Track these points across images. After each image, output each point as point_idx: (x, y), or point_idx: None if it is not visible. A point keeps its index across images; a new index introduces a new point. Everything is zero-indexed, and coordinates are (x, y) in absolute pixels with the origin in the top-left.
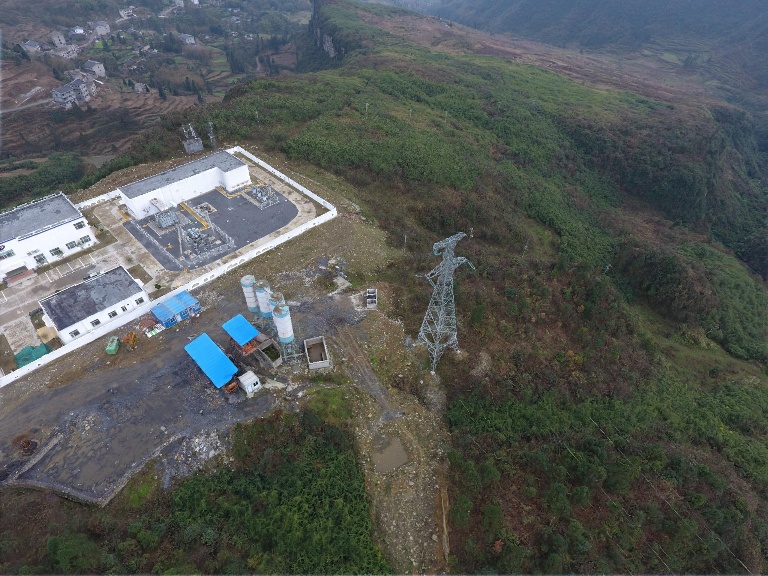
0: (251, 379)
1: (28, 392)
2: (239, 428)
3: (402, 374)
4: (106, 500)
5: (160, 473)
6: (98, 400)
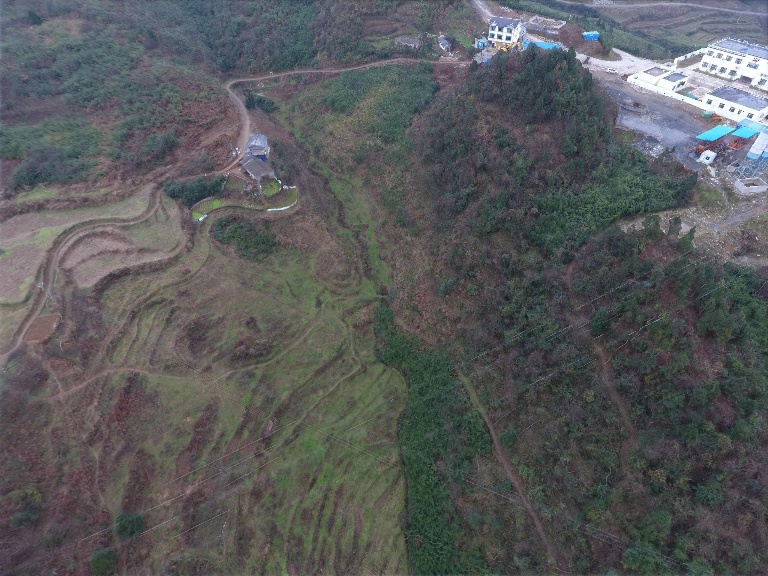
0: (710, 154)
1: (665, 100)
2: (672, 149)
3: (759, 240)
4: (618, 126)
5: (636, 141)
6: (670, 117)
